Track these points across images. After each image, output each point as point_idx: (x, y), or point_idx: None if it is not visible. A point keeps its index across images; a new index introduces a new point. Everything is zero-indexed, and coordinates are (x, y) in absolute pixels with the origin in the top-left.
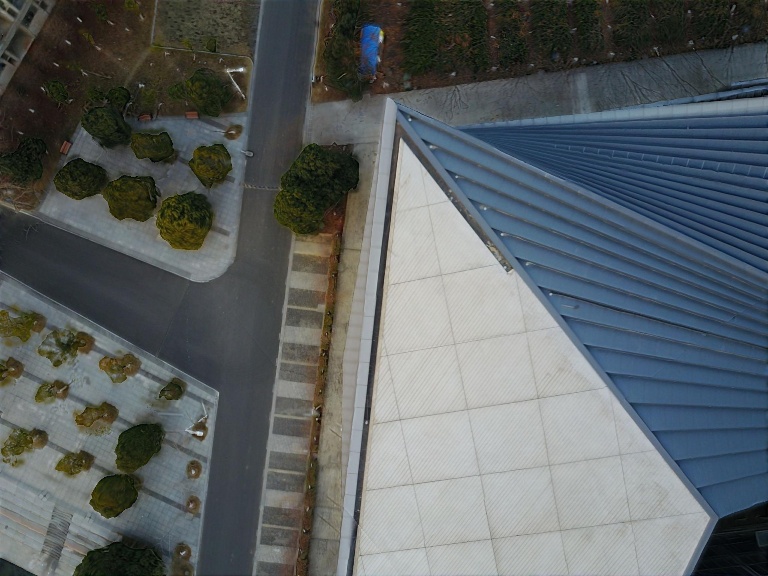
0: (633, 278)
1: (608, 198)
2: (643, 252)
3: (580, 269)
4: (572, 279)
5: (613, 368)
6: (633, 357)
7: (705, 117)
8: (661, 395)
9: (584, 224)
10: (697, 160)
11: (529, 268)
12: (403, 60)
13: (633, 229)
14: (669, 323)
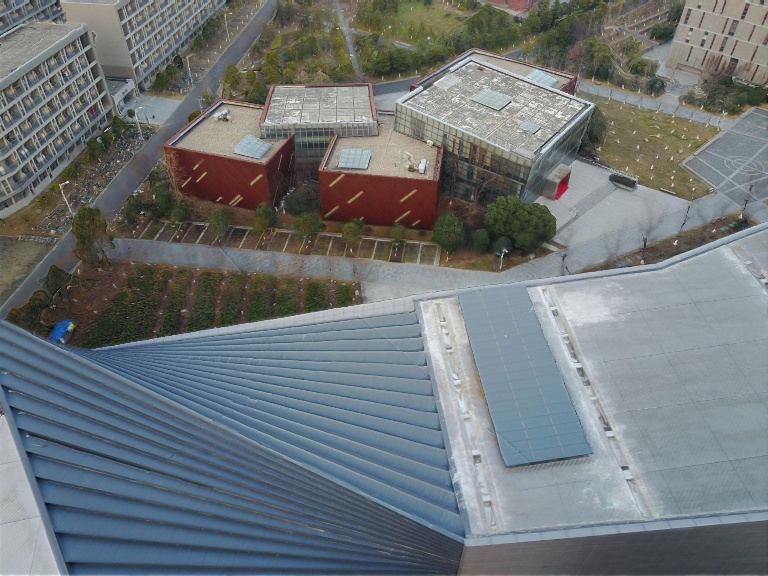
0: (100, 423)
1: (95, 363)
2: (111, 401)
3: (59, 416)
4: (51, 425)
5: (53, 499)
6: (78, 491)
7: (218, 336)
8: (91, 528)
9: (73, 382)
10: (196, 356)
11: (19, 416)
12: (81, 342)
13: (107, 384)
14: (120, 462)
